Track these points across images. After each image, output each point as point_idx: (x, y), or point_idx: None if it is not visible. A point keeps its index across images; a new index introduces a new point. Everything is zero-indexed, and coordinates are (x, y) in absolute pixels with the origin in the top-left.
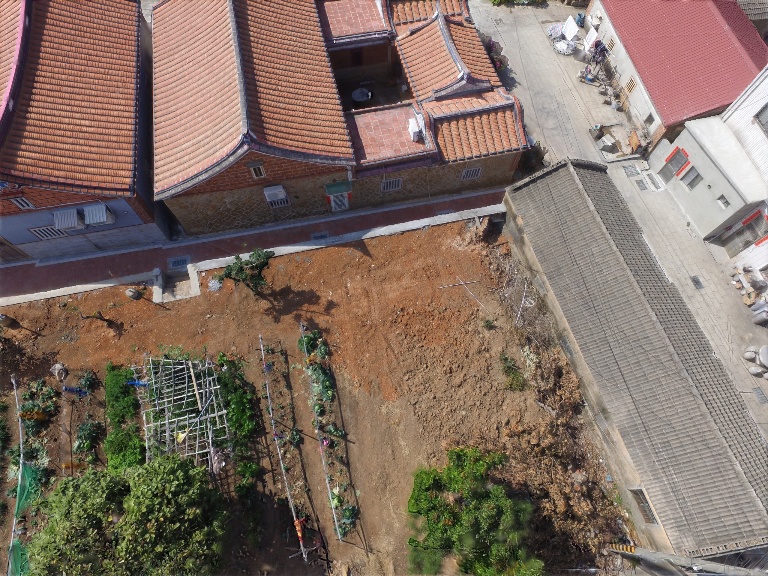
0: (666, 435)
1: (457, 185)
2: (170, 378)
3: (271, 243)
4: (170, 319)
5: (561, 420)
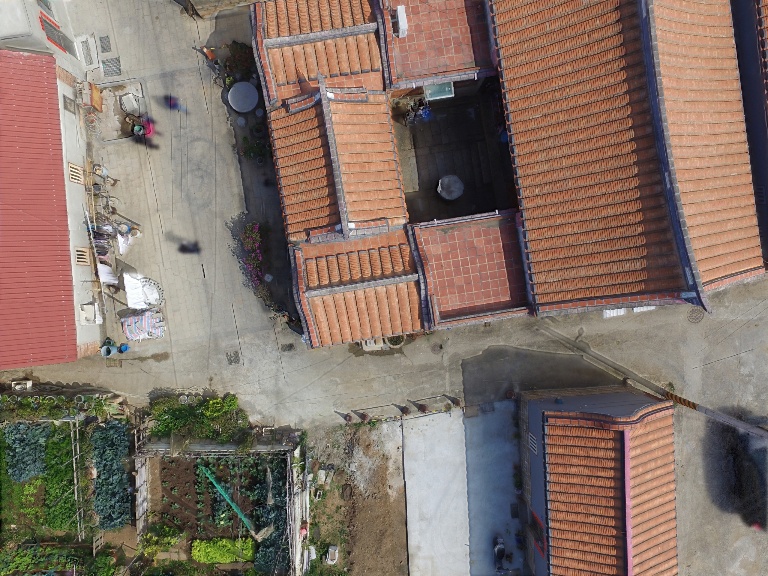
0: None
1: None
2: None
3: None
4: None
5: None
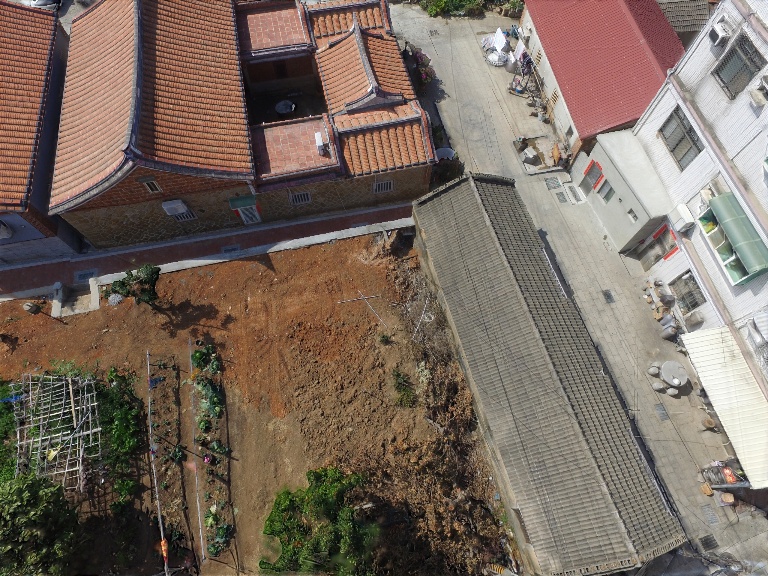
0: (542, 454)
1: (371, 198)
2: (48, 395)
3: (181, 256)
4: (66, 334)
5: (450, 437)
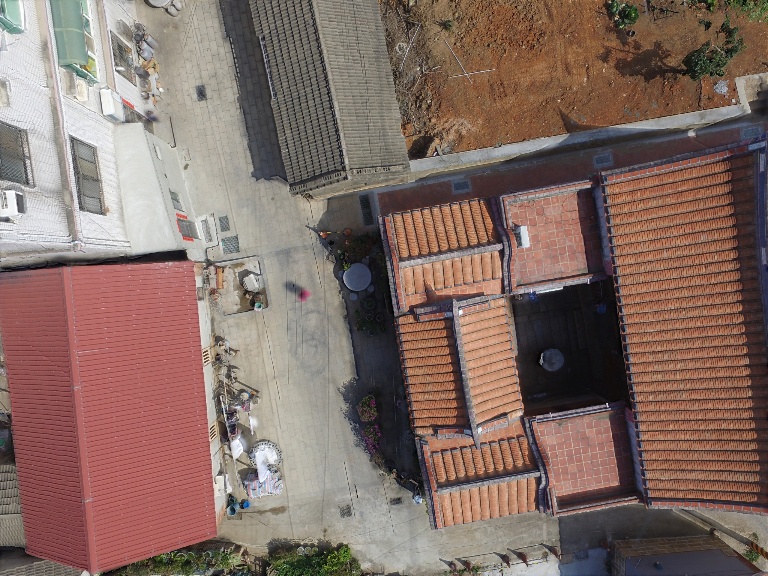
0: None
1: None
2: None
3: (656, 154)
4: (763, 50)
5: None
